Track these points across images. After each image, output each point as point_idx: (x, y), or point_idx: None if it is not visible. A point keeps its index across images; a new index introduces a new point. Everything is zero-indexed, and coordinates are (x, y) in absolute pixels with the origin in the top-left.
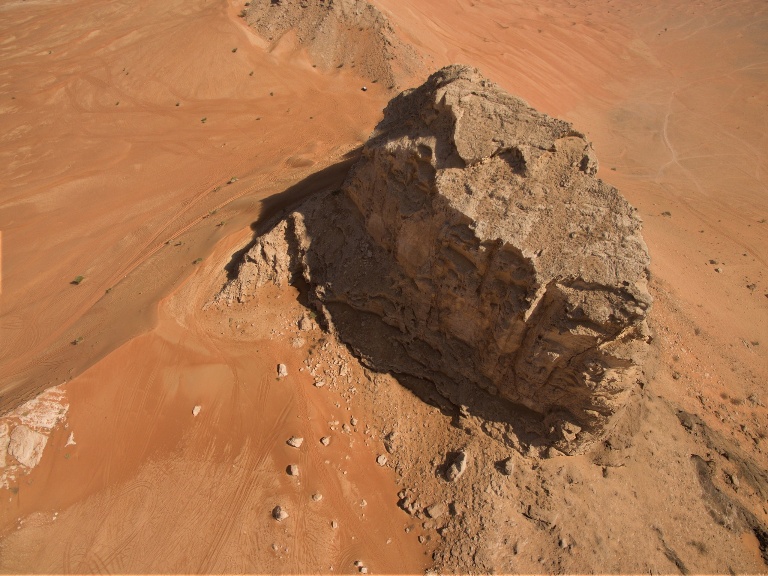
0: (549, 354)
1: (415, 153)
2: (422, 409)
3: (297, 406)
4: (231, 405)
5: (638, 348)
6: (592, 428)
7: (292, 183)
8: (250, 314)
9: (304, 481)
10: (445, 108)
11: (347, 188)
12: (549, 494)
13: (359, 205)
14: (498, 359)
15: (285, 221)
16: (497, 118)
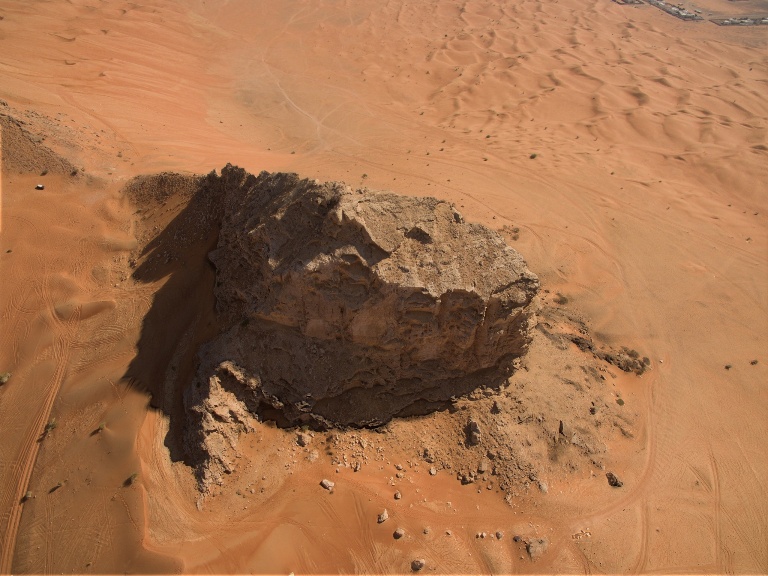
0: (499, 333)
1: None
2: (428, 420)
3: (362, 495)
4: (315, 546)
5: (537, 301)
6: (524, 353)
7: (133, 338)
8: (251, 473)
9: (411, 532)
10: (348, 222)
11: None
12: (521, 403)
13: (282, 321)
14: (464, 355)
15: (215, 377)
16: (388, 213)
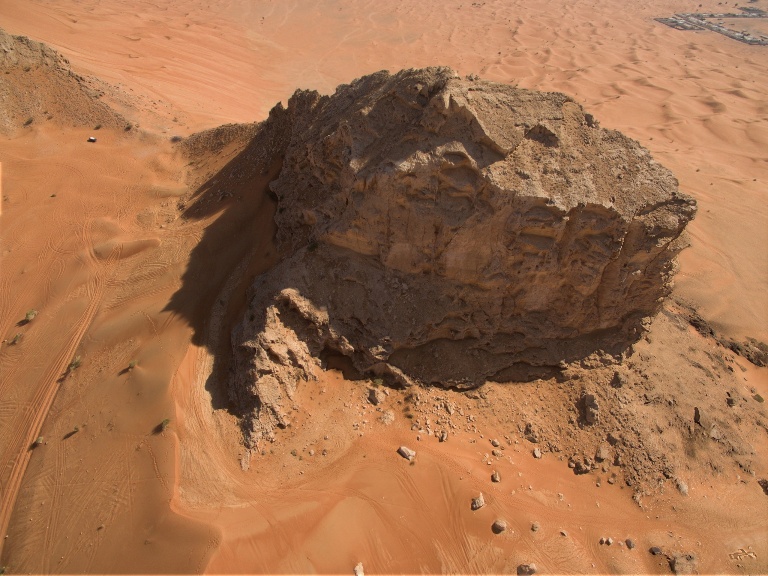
0: (634, 274)
1: (444, 163)
2: (530, 389)
3: (451, 471)
4: (390, 530)
5: (686, 235)
6: (656, 312)
7: (177, 272)
8: (311, 430)
9: (514, 526)
10: (456, 111)
11: (344, 233)
12: (648, 378)
13: (358, 246)
14: (583, 305)
15: (273, 307)
16: (504, 106)
